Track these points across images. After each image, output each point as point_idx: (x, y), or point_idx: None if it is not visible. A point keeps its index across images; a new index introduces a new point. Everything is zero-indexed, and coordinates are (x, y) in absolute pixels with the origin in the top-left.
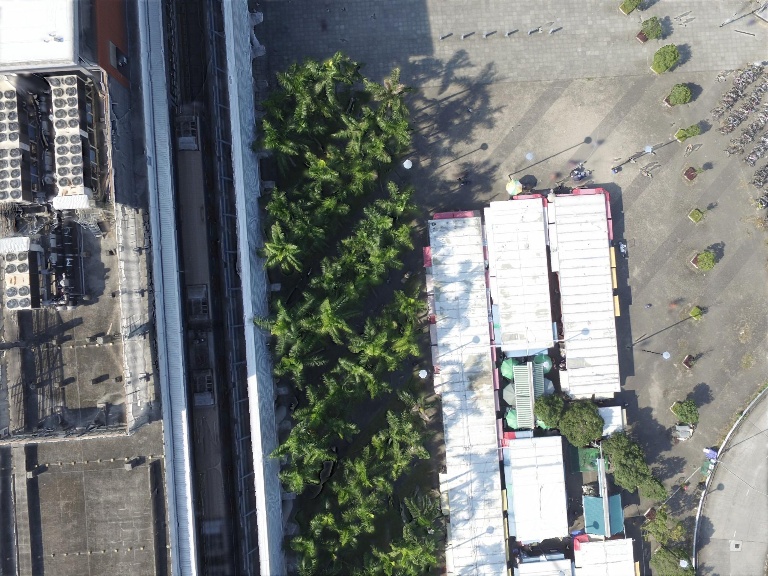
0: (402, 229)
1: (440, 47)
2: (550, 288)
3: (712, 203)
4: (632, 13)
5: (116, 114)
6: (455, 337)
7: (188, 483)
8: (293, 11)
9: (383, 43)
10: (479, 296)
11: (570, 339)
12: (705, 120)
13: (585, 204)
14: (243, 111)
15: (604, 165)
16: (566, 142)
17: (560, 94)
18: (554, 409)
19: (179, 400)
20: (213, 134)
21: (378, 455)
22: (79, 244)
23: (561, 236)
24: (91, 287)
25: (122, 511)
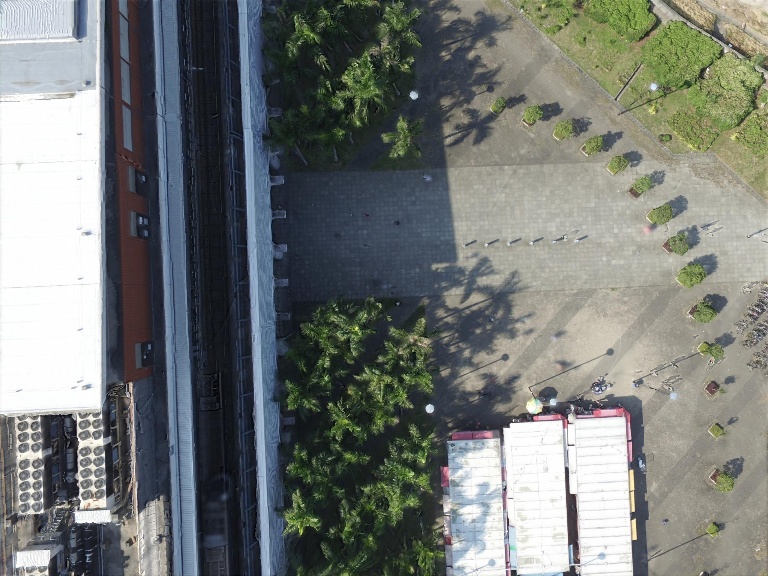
0: (422, 478)
1: (463, 254)
2: (568, 512)
3: (733, 418)
4: None
5: (139, 403)
6: (470, 560)
7: None
8: (315, 215)
9: (406, 249)
10: (496, 519)
11: (586, 564)
12: (729, 333)
13: (606, 427)
14: (266, 365)
15: (625, 378)
16: (588, 354)
17: (583, 304)
18: None
19: None
20: (234, 378)
21: None
22: (99, 533)
23: (580, 459)
24: (110, 575)
25: None
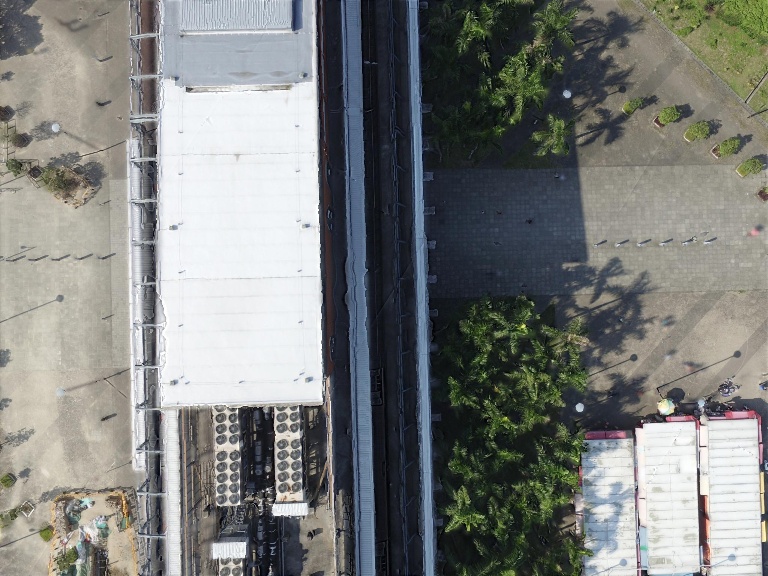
0: (574, 477)
1: (594, 254)
2: (699, 513)
3: None
4: None
5: (323, 397)
6: (602, 559)
7: None
8: (448, 212)
9: (537, 248)
10: (628, 519)
11: (716, 565)
12: None
13: (738, 429)
14: None
15: (752, 380)
16: (715, 355)
17: (711, 306)
18: None
19: None
20: (389, 374)
21: None
22: (279, 526)
23: (713, 461)
24: (289, 568)
25: None
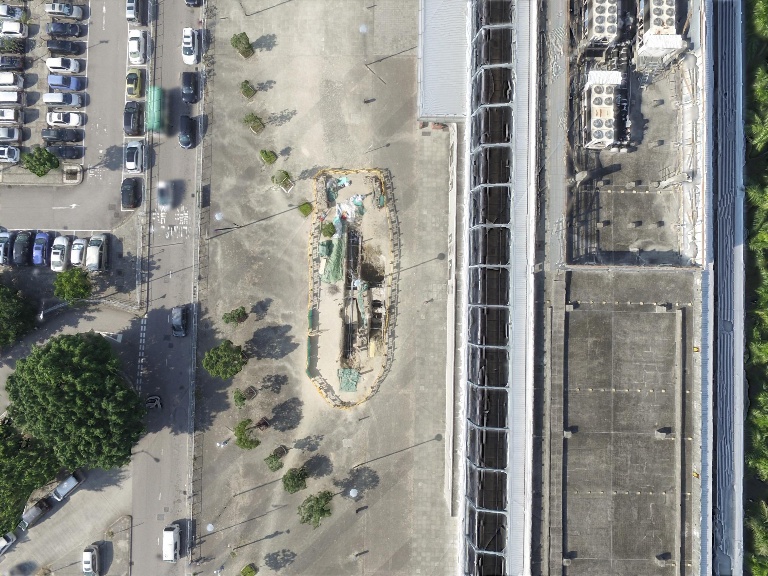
0: None
1: None
2: None
3: None
4: None
5: None
6: None
7: (711, 333)
8: None
9: None
10: None
11: None
12: None
13: None
14: None
15: None
16: None
17: None
18: None
19: (707, 252)
20: None
21: None
22: None
23: None
24: None
25: (647, 353)
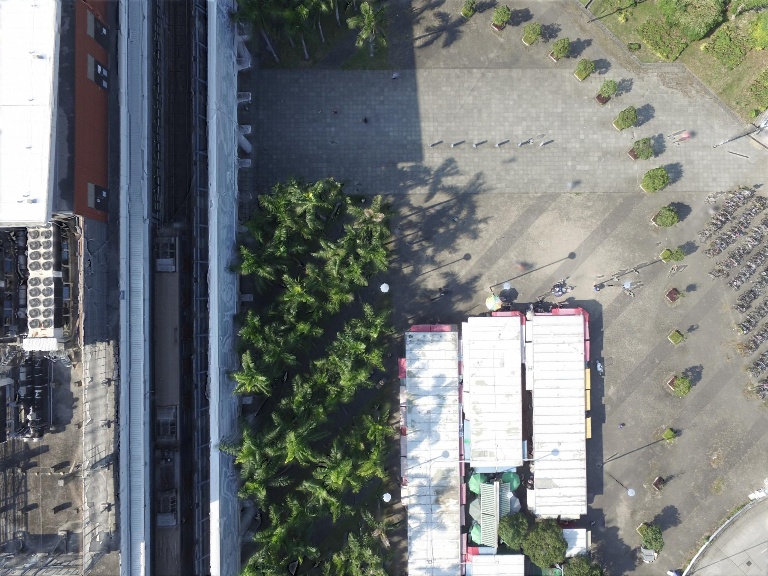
0: (375, 354)
1: (429, 154)
2: (523, 407)
3: (693, 326)
4: (625, 129)
5: (92, 247)
6: (425, 450)
7: None
8: (285, 110)
9: (373, 147)
10: (451, 411)
11: (539, 459)
12: (692, 241)
13: (563, 325)
14: (222, 233)
15: (586, 282)
16: (550, 256)
17: (547, 208)
18: (518, 531)
19: (139, 532)
20: None
21: (338, 574)
22: (49, 373)
23: (537, 356)
24: (59, 415)
25: None
